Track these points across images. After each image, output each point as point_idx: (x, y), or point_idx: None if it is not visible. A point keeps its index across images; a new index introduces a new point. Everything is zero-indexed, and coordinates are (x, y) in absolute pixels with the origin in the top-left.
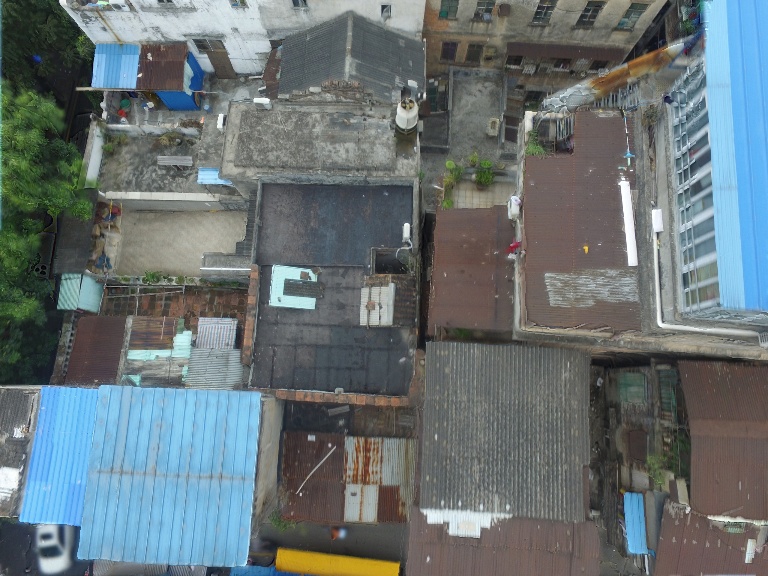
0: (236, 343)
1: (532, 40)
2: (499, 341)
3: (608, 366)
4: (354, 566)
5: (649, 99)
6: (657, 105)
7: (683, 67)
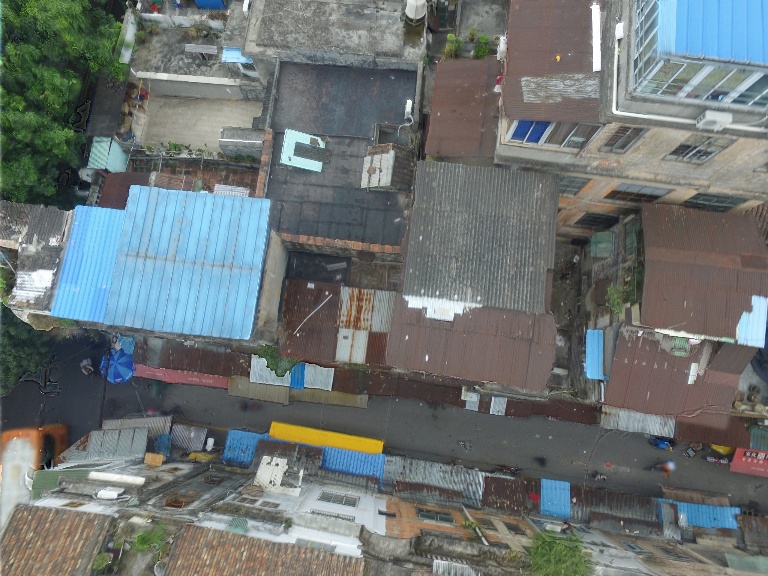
0: None
1: None
2: None
3: (585, 244)
4: (341, 441)
5: None
6: None
7: None
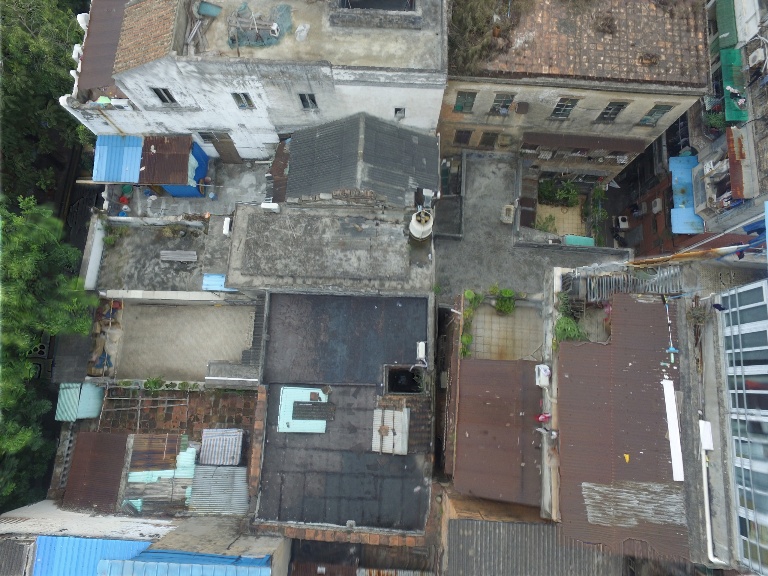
0: (242, 454)
1: (549, 131)
2: (525, 513)
3: None
4: None
5: (693, 287)
6: (704, 304)
7: (733, 265)
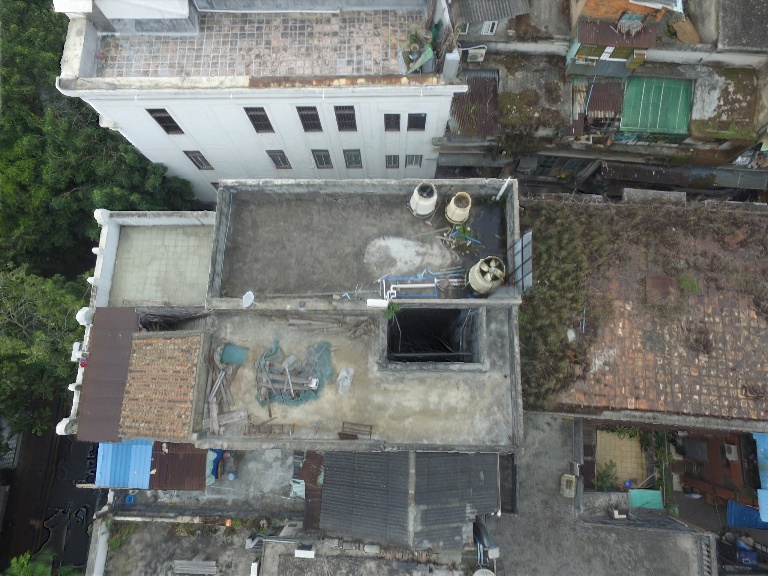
0: None
1: None
2: None
3: None
4: None
5: None
6: None
7: None
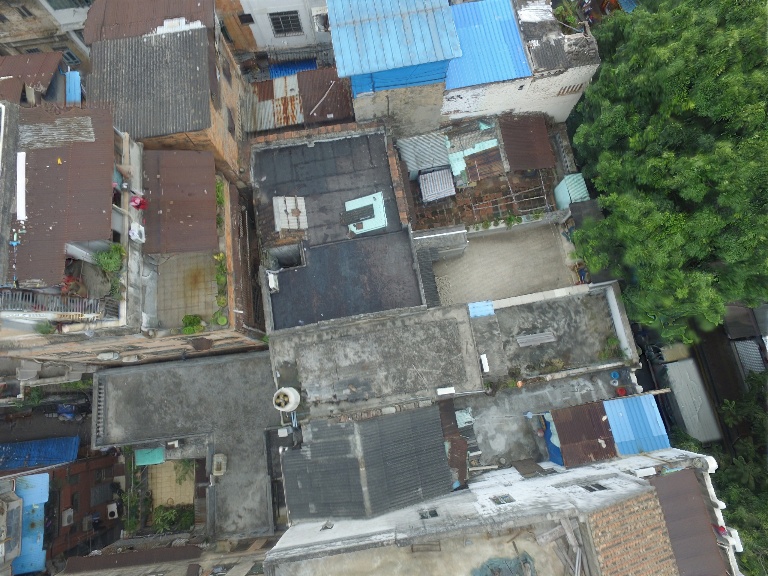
0: None
1: None
2: (157, 148)
3: None
4: None
5: None
6: None
7: None
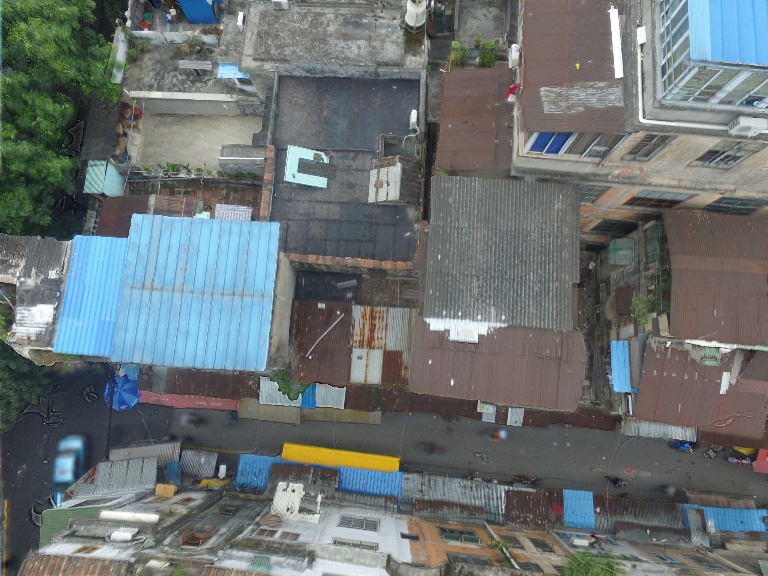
0: None
1: None
2: None
3: (600, 250)
4: (356, 460)
5: None
6: None
7: None
